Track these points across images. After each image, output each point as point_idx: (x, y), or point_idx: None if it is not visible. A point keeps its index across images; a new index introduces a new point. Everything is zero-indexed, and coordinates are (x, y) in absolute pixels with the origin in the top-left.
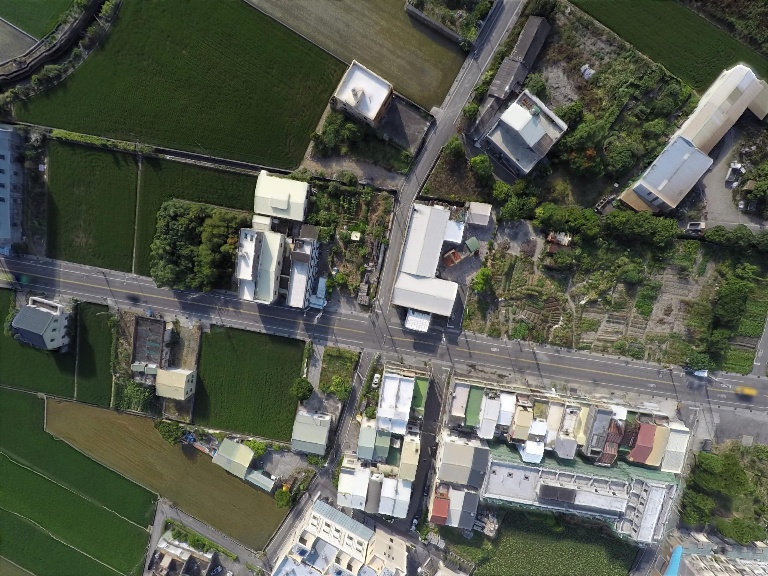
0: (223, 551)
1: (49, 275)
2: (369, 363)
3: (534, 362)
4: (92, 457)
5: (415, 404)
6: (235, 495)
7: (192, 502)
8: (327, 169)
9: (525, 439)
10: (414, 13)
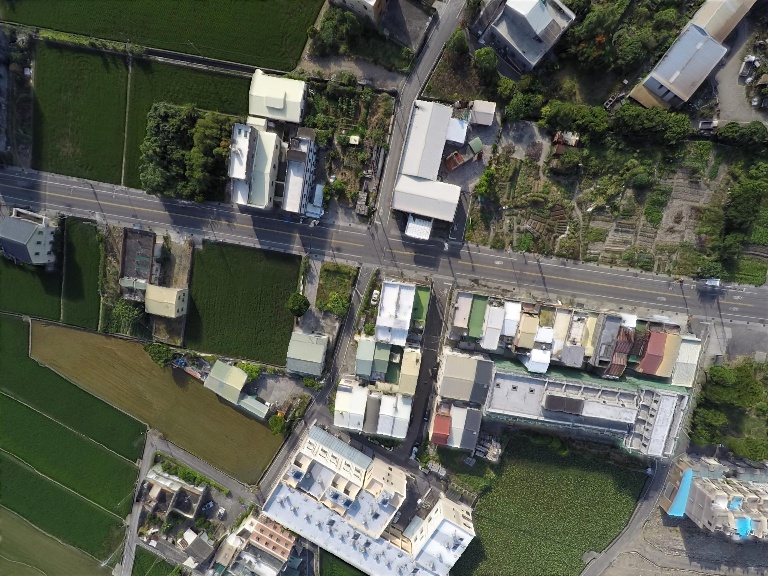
0: (215, 485)
1: (35, 188)
2: (368, 279)
3: (539, 275)
4: (79, 385)
5: (416, 316)
6: (228, 425)
7: (183, 433)
8: (325, 69)
9: (530, 348)
10: None
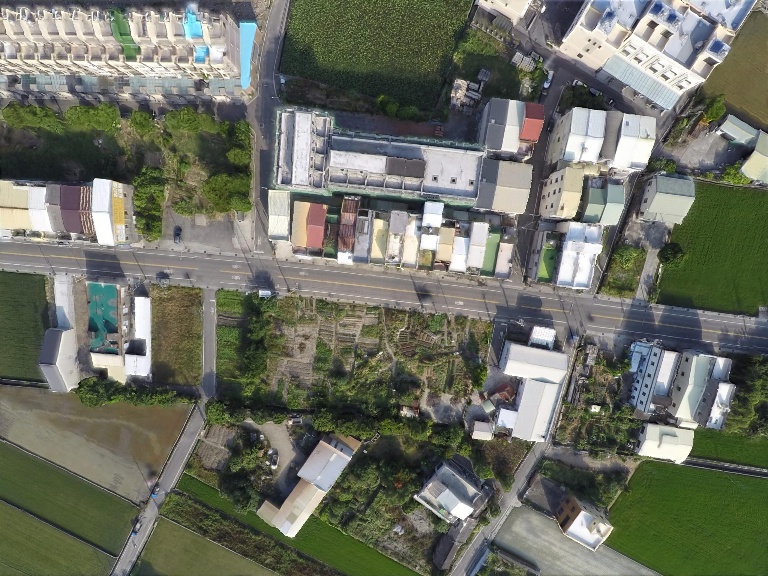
0: None
1: None
2: None
3: (420, 292)
4: None
5: (552, 251)
6: None
7: None
8: (615, 462)
9: (442, 228)
10: (534, 569)
